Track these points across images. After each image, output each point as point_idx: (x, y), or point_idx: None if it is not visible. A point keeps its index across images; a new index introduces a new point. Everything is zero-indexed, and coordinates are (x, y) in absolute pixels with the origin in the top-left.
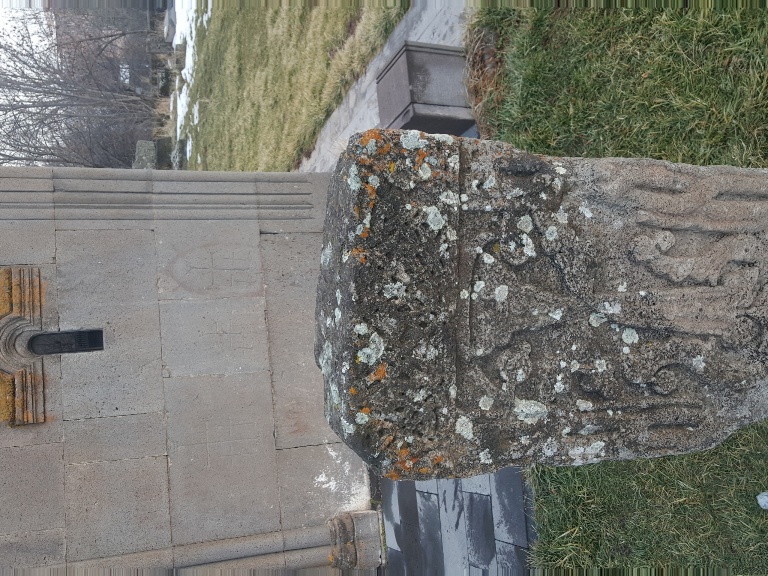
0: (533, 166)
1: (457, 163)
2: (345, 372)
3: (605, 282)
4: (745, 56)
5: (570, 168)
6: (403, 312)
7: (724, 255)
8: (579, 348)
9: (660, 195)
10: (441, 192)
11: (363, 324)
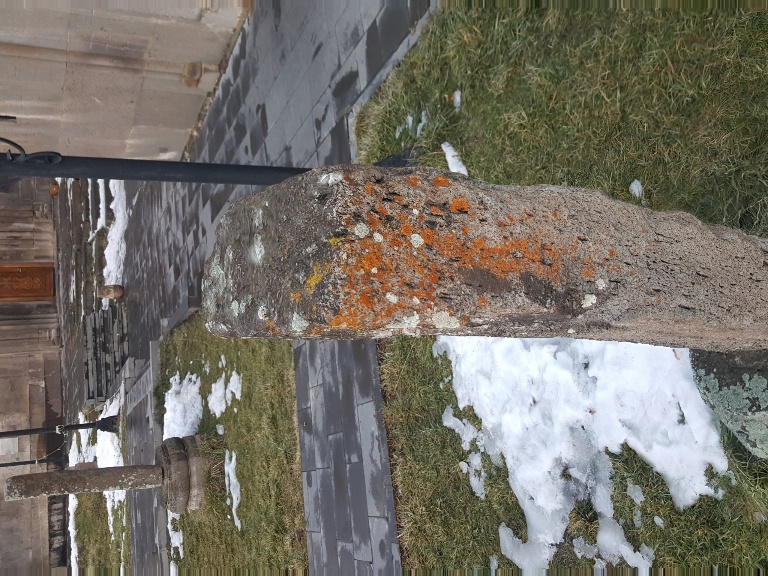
0: None
1: None
2: None
3: None
4: None
5: (603, 300)
6: None
7: None
8: None
9: None
10: None
11: None
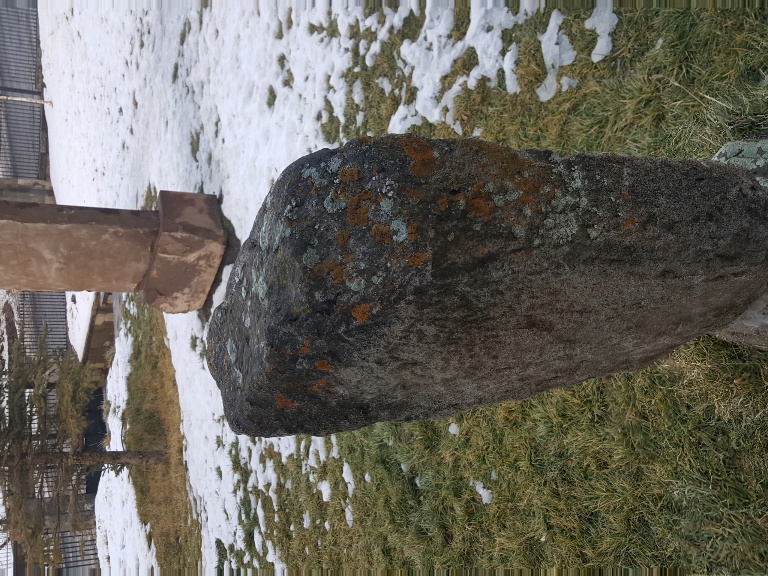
0: None
1: None
2: None
3: None
4: (711, 570)
5: None
6: None
7: None
8: None
9: None
10: None
11: None
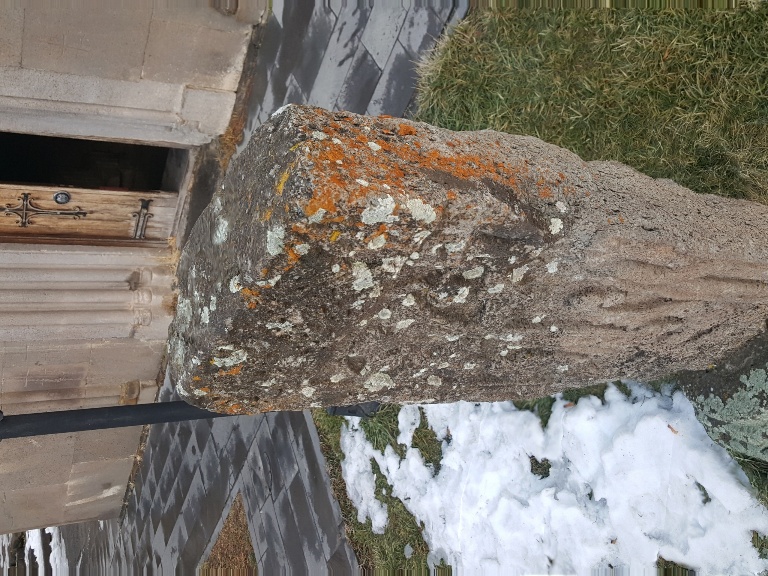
0: (522, 235)
1: (425, 235)
2: (195, 363)
3: (525, 311)
4: None
5: (569, 223)
6: (281, 339)
7: (660, 313)
8: (457, 357)
9: (644, 268)
10: (387, 256)
11: (229, 345)
